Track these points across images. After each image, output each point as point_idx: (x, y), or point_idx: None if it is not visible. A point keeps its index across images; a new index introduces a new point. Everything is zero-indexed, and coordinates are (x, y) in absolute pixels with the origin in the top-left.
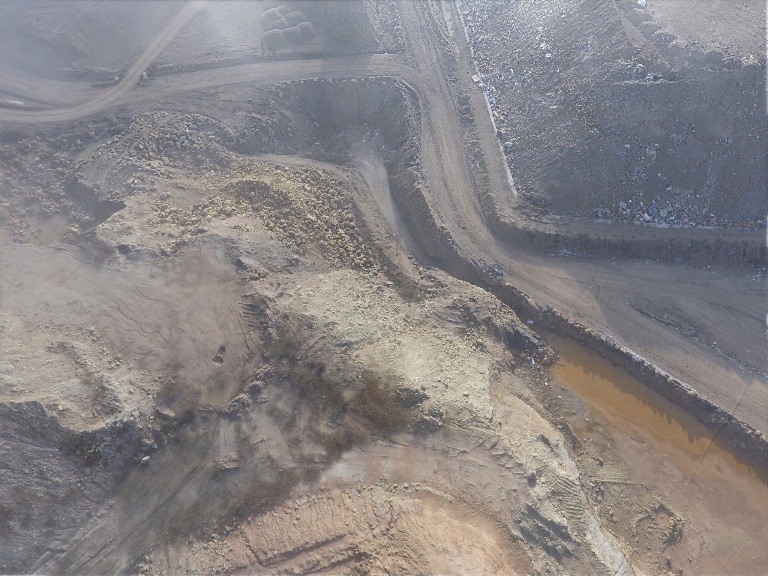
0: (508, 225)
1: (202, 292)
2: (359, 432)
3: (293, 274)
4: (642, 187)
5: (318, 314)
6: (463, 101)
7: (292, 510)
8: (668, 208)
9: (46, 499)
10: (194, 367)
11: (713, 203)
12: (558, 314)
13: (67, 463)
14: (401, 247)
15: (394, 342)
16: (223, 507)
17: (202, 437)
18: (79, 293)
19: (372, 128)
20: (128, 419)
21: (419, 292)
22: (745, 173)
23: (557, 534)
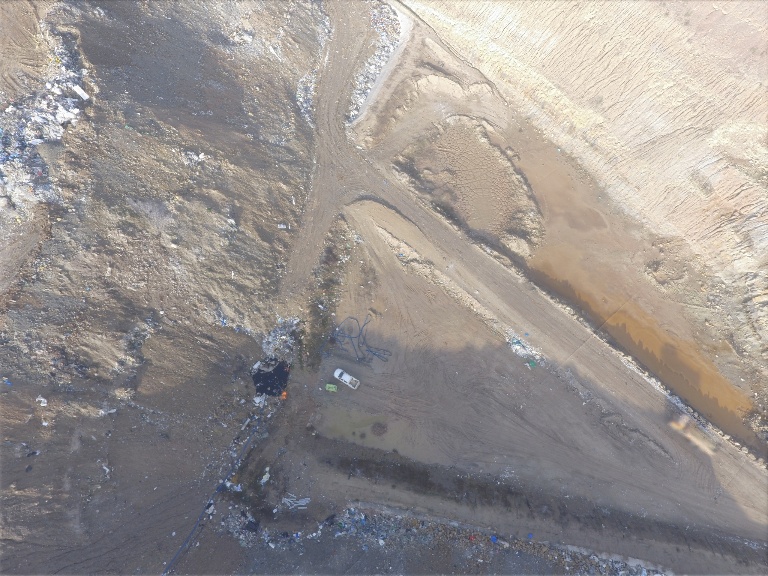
0: None
1: None
2: None
3: None
4: None
5: None
6: None
7: None
8: None
9: None
10: None
11: None
12: (762, 460)
13: None
14: None
15: None
16: None
17: None
18: None
19: None
20: None
21: None
22: None
23: None
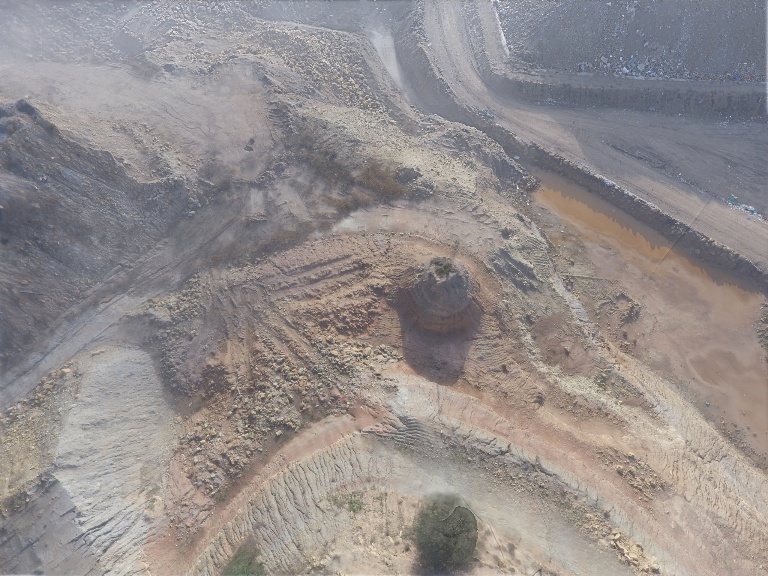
0: (500, 77)
1: (234, 100)
2: (364, 198)
3: (310, 99)
4: (622, 43)
5: (331, 121)
6: None
7: (309, 246)
8: (645, 62)
9: (117, 227)
10: (229, 153)
11: (686, 58)
12: (541, 148)
13: (132, 205)
14: (405, 99)
15: (395, 149)
16: (254, 246)
17: (237, 200)
18: (133, 99)
19: (381, 4)
20: (178, 179)
21: (419, 129)
22: (716, 29)
23: (524, 273)
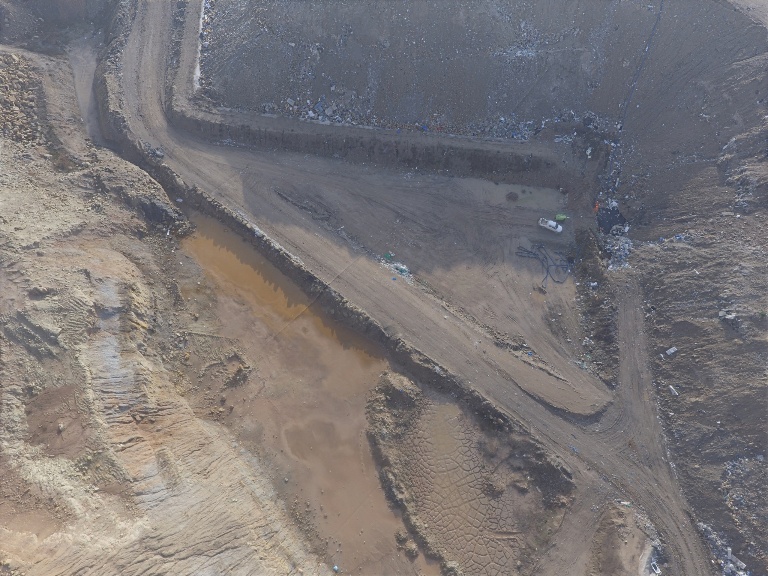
0: (178, 113)
1: None
2: None
3: None
4: (310, 86)
5: None
6: (180, 5)
7: None
8: (332, 107)
9: None
10: None
11: (375, 105)
12: (199, 192)
13: None
14: (84, 131)
15: None
16: None
17: None
18: None
19: (97, 27)
20: None
21: (73, 165)
22: (403, 77)
23: (45, 339)
